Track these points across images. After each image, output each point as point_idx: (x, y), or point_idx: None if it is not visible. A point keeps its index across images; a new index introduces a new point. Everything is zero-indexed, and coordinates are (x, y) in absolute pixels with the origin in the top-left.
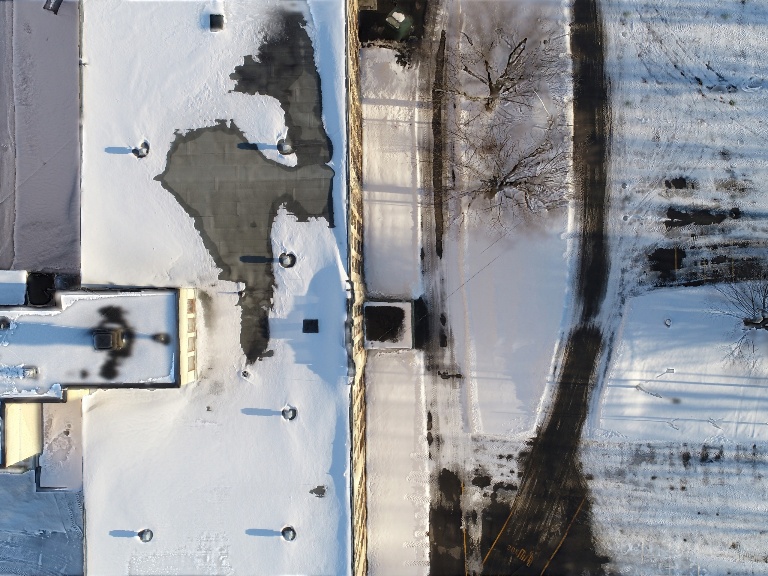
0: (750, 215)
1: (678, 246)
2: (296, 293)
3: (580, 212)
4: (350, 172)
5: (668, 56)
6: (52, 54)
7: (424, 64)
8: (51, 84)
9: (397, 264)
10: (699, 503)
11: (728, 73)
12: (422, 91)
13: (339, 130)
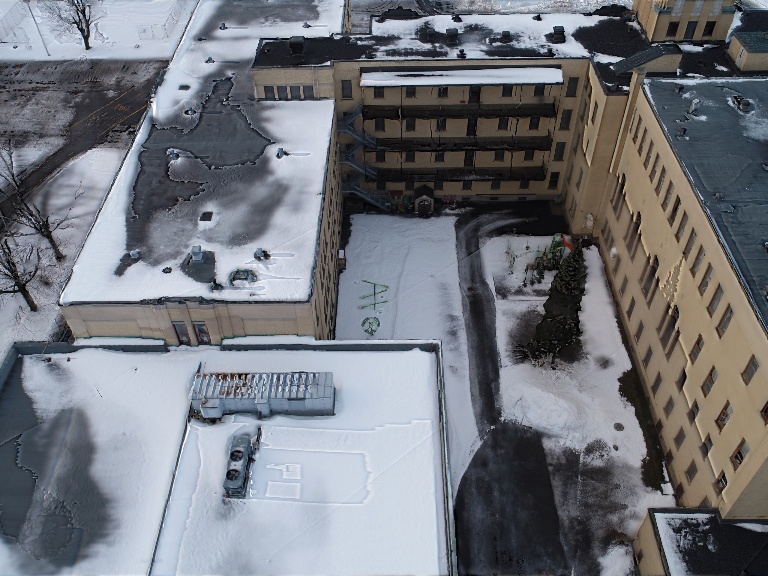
0: None
1: None
2: (190, 101)
3: None
4: None
5: None
6: None
7: None
8: (429, 328)
9: None
10: (0, 127)
11: None
12: None
13: (130, 163)
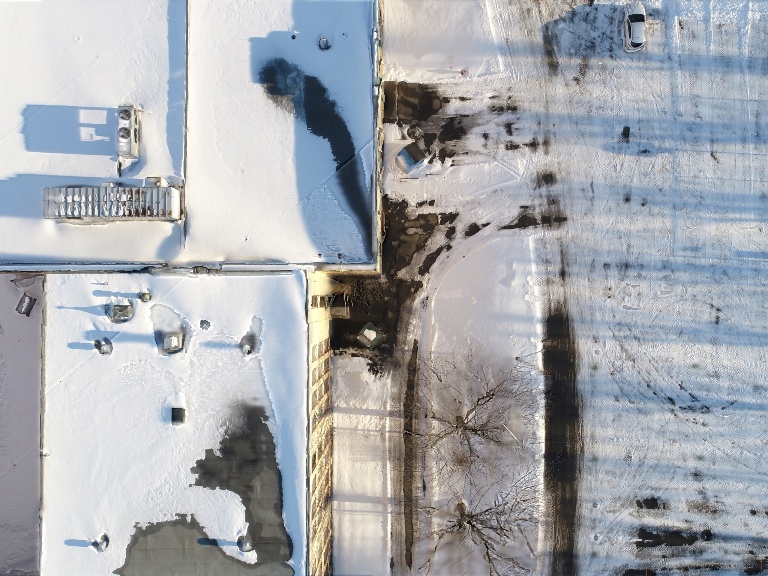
0: (722, 537)
1: (649, 567)
2: None
3: (550, 530)
4: (310, 572)
5: (641, 375)
6: (24, 355)
7: (396, 373)
8: (22, 385)
9: (366, 575)
10: None
11: (701, 394)
12: (394, 400)
13: (299, 529)
